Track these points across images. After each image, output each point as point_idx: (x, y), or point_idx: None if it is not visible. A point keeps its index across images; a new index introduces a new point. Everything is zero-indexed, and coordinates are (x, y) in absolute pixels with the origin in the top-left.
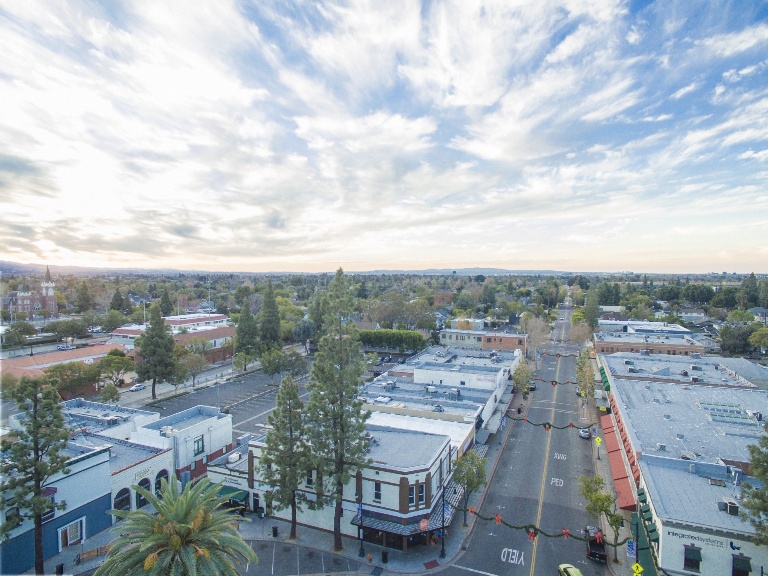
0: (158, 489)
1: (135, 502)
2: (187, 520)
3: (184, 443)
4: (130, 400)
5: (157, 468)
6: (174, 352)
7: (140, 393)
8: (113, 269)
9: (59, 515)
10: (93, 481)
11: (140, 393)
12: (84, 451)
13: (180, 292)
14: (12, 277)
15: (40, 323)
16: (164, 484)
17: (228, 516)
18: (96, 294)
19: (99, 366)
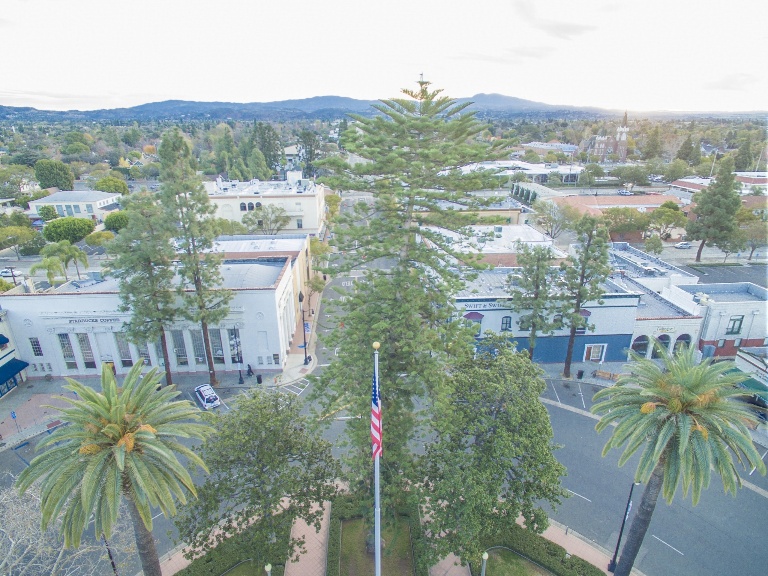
0: (676, 349)
1: (651, 351)
2: (698, 391)
3: (718, 316)
4: (672, 256)
5: (681, 330)
6: (736, 215)
7: (684, 251)
8: (691, 112)
9: (588, 334)
10: (620, 318)
11: (684, 251)
12: (618, 290)
13: (767, 142)
14: (595, 121)
15: (609, 167)
16: (684, 347)
17: (747, 410)
18: (665, 141)
19: (650, 216)
